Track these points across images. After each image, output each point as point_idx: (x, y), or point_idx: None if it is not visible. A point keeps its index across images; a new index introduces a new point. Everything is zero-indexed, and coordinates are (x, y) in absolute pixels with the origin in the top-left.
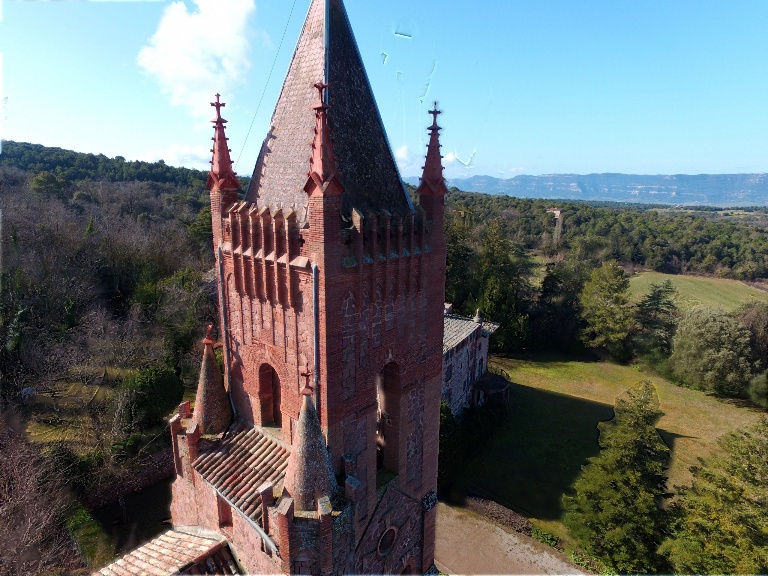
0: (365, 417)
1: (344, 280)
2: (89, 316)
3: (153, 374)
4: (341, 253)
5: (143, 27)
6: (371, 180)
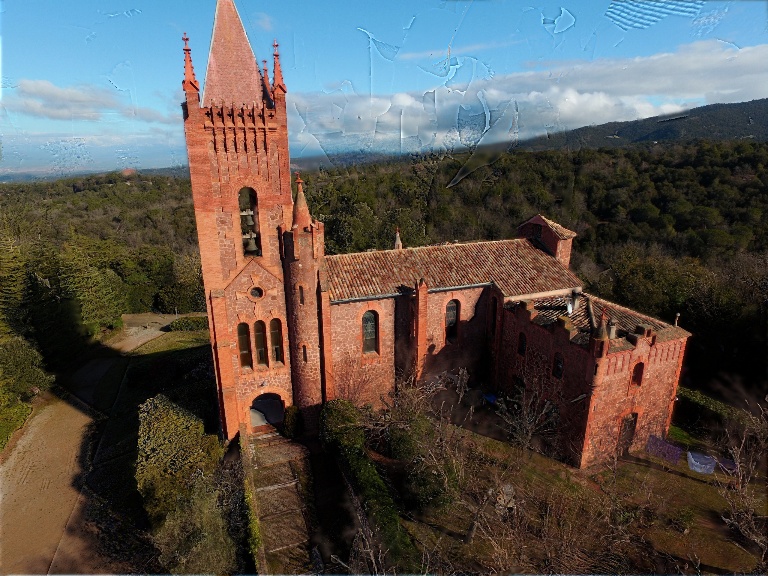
0: None
1: None
2: None
3: None
4: None
5: None
6: None
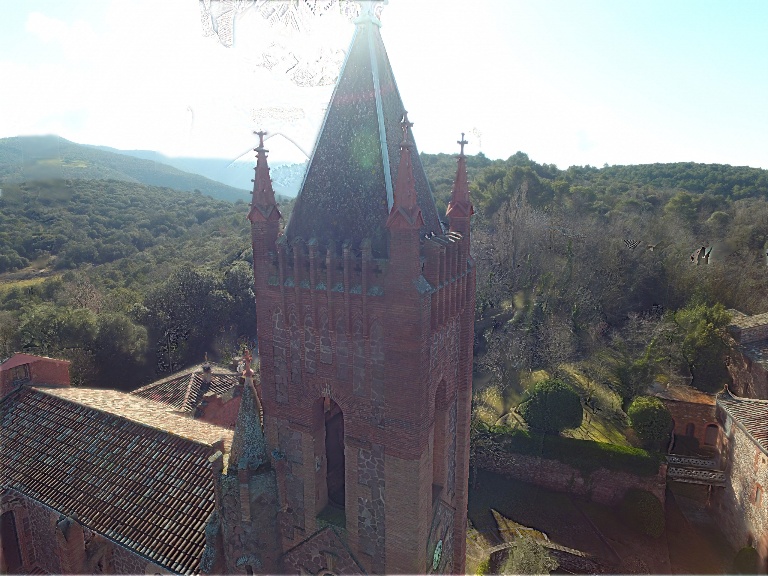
0: (300, 433)
1: (273, 295)
2: (589, 325)
3: (553, 386)
4: (269, 271)
5: (464, 77)
6: (347, 209)
